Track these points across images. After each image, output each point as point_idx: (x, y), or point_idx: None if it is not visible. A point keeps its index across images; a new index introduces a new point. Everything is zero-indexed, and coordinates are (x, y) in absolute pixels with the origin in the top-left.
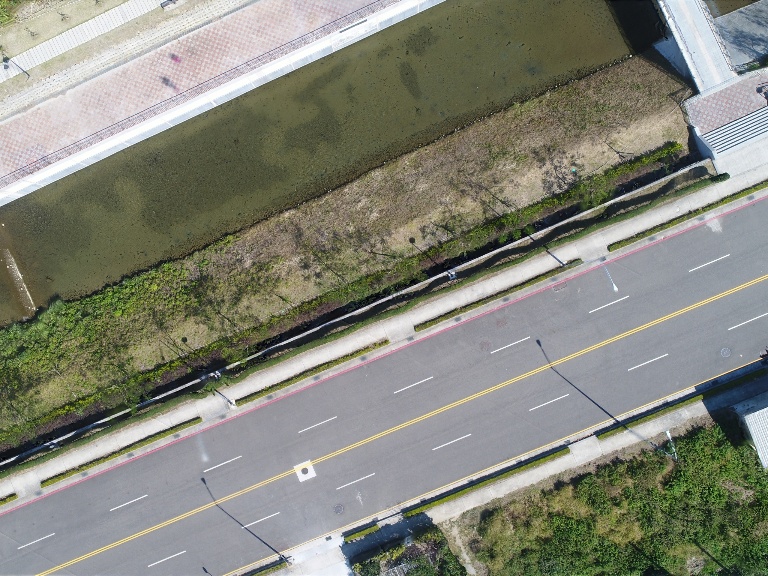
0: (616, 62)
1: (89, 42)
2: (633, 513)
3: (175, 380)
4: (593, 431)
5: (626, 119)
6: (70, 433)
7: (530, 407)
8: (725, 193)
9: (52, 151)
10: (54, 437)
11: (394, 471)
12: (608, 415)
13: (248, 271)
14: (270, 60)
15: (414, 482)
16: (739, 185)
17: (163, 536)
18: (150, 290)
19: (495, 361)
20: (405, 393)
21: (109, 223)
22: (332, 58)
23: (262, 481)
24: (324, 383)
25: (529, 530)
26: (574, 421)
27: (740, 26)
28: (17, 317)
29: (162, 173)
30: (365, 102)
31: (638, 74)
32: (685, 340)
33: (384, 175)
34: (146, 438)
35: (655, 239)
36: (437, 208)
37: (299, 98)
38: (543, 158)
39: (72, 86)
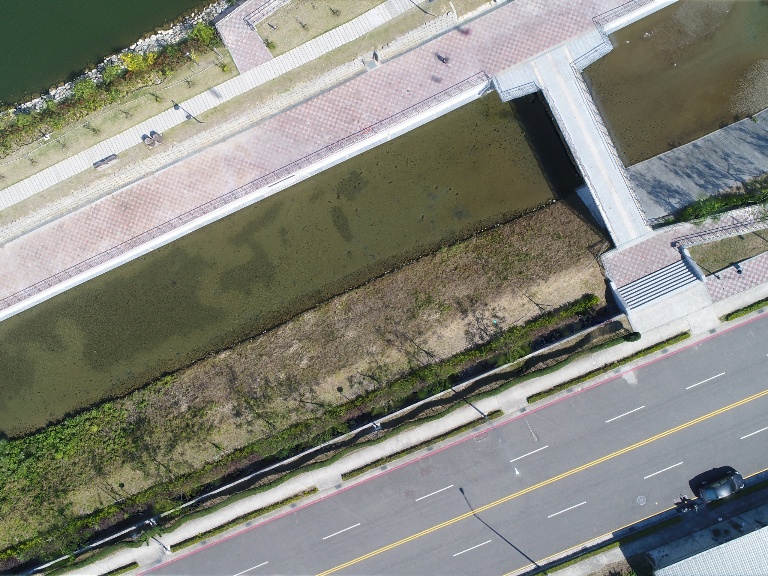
0: (540, 207)
1: (25, 201)
2: None
3: (113, 525)
4: (515, 575)
5: (545, 271)
6: None
7: (454, 553)
8: (640, 347)
9: None
10: None
11: None
12: (529, 560)
13: (183, 416)
14: (201, 214)
15: None
16: (653, 339)
17: None
18: (90, 431)
19: (420, 508)
20: (334, 539)
21: (52, 362)
22: (265, 202)
23: None
24: (256, 529)
25: None
26: (496, 566)
27: (658, 175)
28: None
29: (102, 314)
30: (298, 245)
31: (560, 222)
32: (602, 488)
33: (316, 318)
34: None
35: (573, 391)
36: (364, 358)
37: (234, 241)
38: (466, 310)
39: (10, 239)
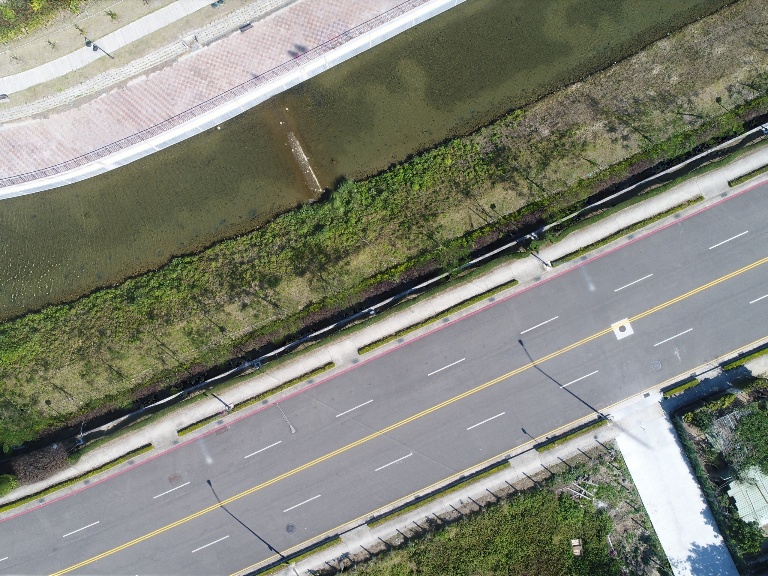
0: None
1: None
2: None
3: (487, 245)
4: None
5: None
6: (388, 299)
7: None
8: None
9: (354, 26)
10: (364, 307)
11: (711, 326)
12: None
13: (549, 139)
14: None
15: (732, 336)
16: None
17: (482, 398)
18: (444, 164)
19: None
20: (721, 248)
21: (392, 104)
22: None
23: (580, 340)
24: (638, 242)
25: None
26: None
27: None
28: (303, 200)
29: (444, 53)
30: None
31: None
32: None
33: (672, 44)
34: (462, 302)
35: None
36: (743, 67)
37: None
38: None
39: None
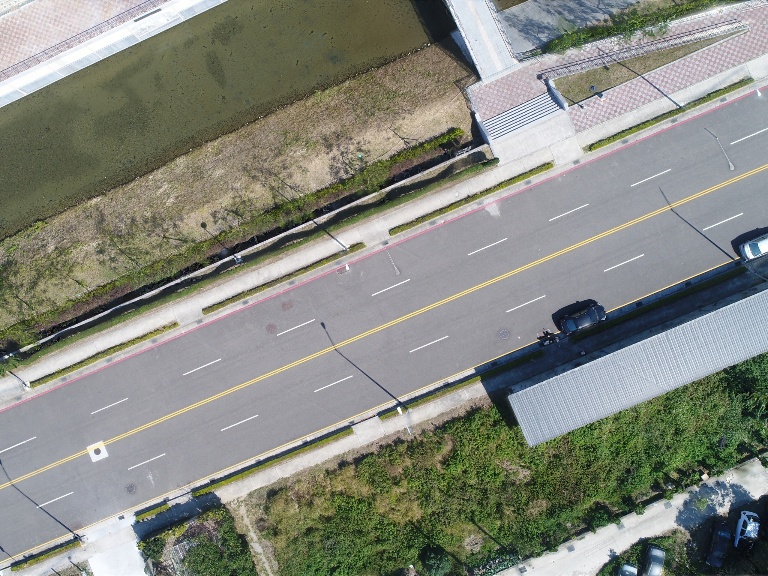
0: (415, 50)
1: None
2: (412, 492)
3: None
4: (376, 412)
5: (412, 106)
6: None
7: (315, 388)
8: (502, 178)
9: None
10: None
11: (184, 451)
12: (391, 396)
13: (49, 256)
14: (66, 49)
15: (203, 462)
16: (516, 170)
17: None
18: None
19: (281, 343)
20: (194, 375)
21: None
22: (140, 47)
23: (56, 461)
24: (116, 365)
25: (311, 509)
26: (358, 402)
27: (531, 14)
28: None
29: None
30: (172, 90)
31: (431, 62)
32: (464, 322)
33: (187, 162)
34: None
35: (436, 223)
36: (228, 193)
37: (108, 87)
38: (331, 144)
39: None
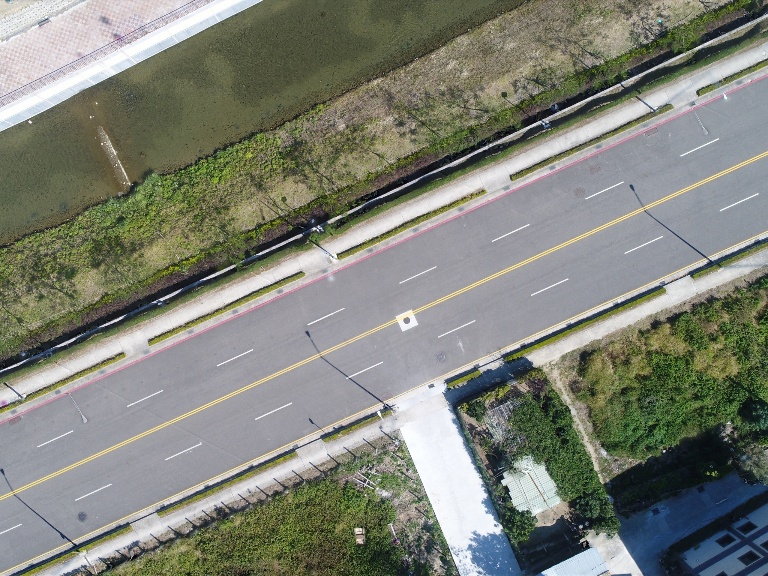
0: None
1: None
2: (730, 348)
3: (276, 238)
4: (687, 271)
5: None
6: (176, 291)
7: (625, 250)
8: None
9: (149, 21)
10: None
11: (494, 317)
12: (701, 255)
13: (343, 133)
14: None
15: (514, 328)
16: None
17: (269, 389)
18: (245, 158)
19: (590, 207)
20: (503, 241)
21: (200, 98)
22: None
23: (365, 332)
24: (423, 234)
25: (629, 368)
26: (668, 262)
27: None
28: (112, 193)
29: (251, 48)
30: None
31: None
32: None
33: (470, 40)
34: (250, 294)
35: (742, 83)
36: (528, 62)
37: None
38: (629, 11)
39: None
